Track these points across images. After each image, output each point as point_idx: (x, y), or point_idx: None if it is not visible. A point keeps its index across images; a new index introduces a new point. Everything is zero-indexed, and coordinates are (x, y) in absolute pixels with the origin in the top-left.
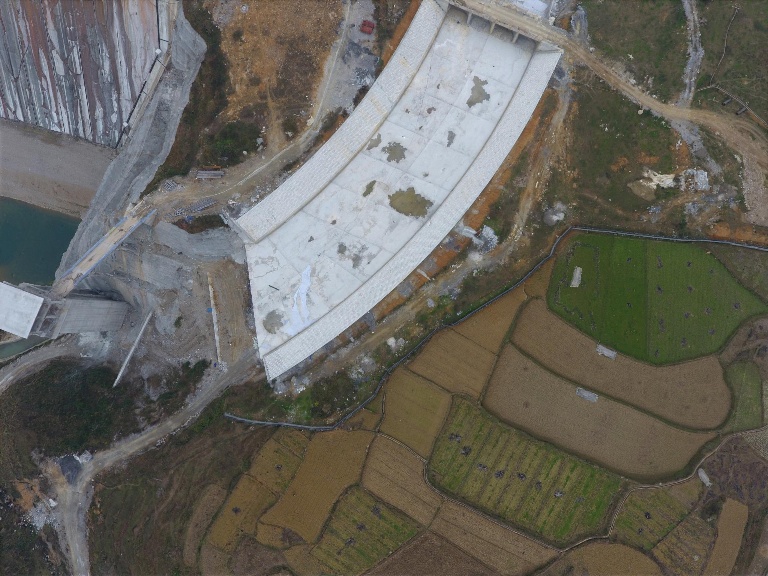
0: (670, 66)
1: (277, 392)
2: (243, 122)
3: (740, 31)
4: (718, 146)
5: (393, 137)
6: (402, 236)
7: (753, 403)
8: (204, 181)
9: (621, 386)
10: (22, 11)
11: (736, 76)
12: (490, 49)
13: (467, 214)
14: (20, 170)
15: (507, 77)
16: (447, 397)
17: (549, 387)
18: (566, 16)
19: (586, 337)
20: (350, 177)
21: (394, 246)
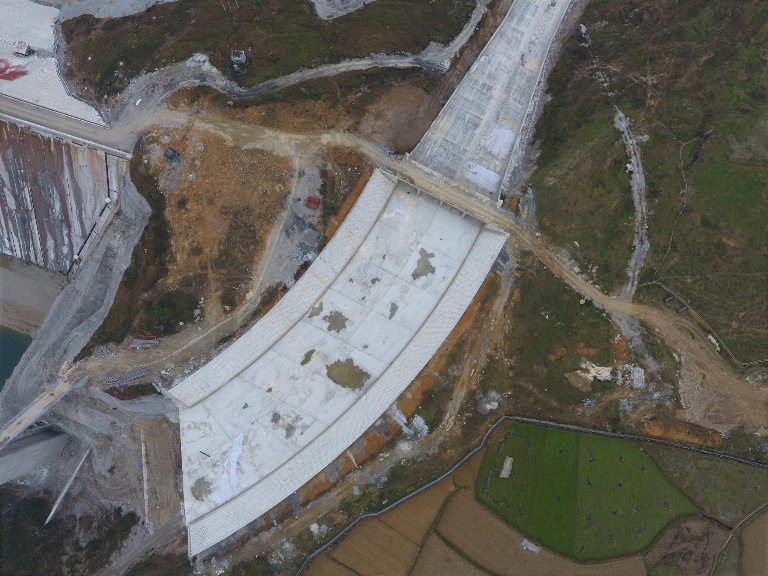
0: (615, 257)
1: (196, 572)
2: (182, 291)
3: (687, 227)
4: (657, 343)
5: (335, 306)
6: (337, 408)
7: None
8: (138, 350)
9: None
10: None
11: (680, 273)
12: (439, 221)
13: (401, 397)
14: None
15: (454, 251)
16: None
17: None
18: (515, 197)
19: (512, 530)
20: (289, 345)
21: (328, 418)
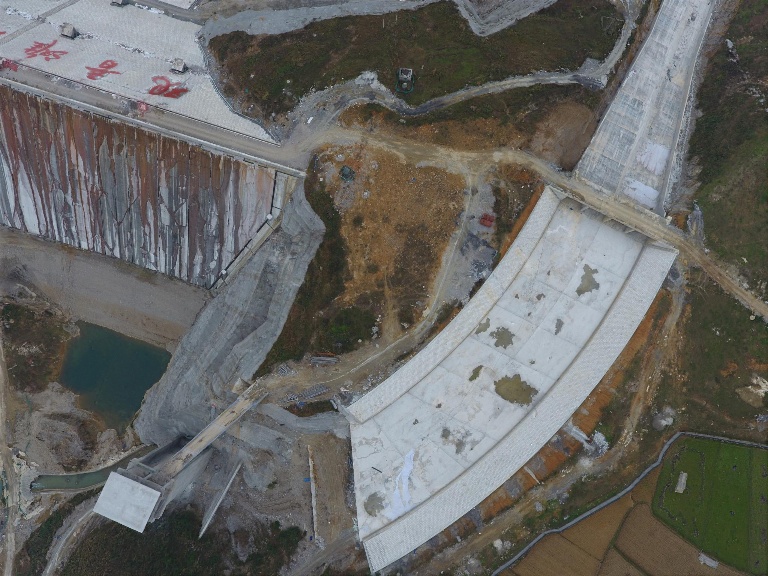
0: None
1: None
2: (359, 308)
3: None
4: None
5: (502, 322)
6: (506, 423)
7: None
8: (318, 367)
9: None
10: (136, 169)
11: None
12: (602, 238)
13: (576, 413)
14: (111, 302)
15: (617, 267)
16: None
17: None
18: (681, 213)
19: (689, 545)
20: (457, 361)
21: (498, 433)
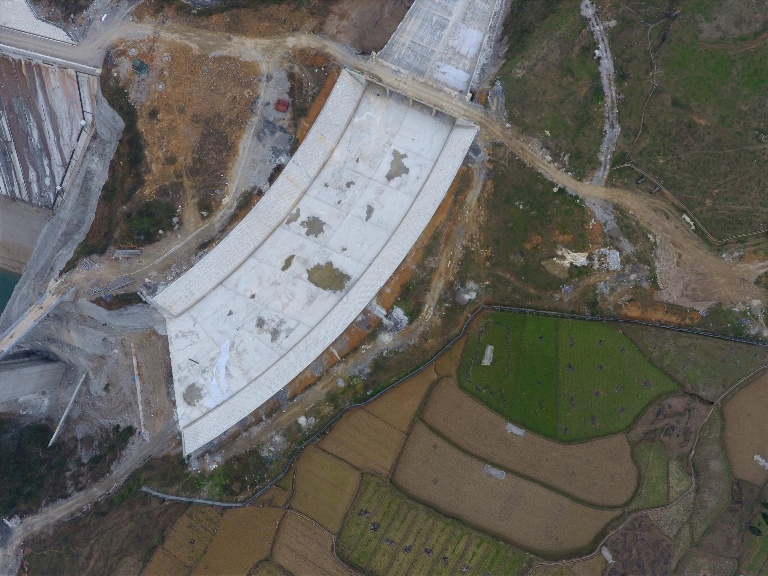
0: (586, 143)
1: (191, 468)
2: (160, 201)
3: (657, 108)
4: (632, 225)
5: (312, 211)
6: (320, 310)
7: (659, 481)
8: (121, 260)
9: (529, 463)
10: None
11: (651, 154)
12: (410, 122)
13: (380, 292)
14: None
15: (426, 150)
16: (356, 475)
17: (458, 464)
18: (484, 91)
19: (496, 415)
20: (269, 251)
21: (312, 320)
